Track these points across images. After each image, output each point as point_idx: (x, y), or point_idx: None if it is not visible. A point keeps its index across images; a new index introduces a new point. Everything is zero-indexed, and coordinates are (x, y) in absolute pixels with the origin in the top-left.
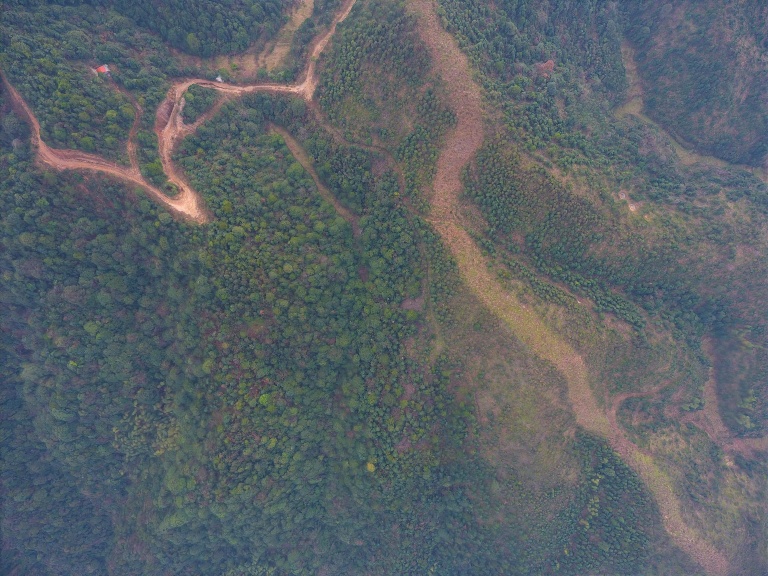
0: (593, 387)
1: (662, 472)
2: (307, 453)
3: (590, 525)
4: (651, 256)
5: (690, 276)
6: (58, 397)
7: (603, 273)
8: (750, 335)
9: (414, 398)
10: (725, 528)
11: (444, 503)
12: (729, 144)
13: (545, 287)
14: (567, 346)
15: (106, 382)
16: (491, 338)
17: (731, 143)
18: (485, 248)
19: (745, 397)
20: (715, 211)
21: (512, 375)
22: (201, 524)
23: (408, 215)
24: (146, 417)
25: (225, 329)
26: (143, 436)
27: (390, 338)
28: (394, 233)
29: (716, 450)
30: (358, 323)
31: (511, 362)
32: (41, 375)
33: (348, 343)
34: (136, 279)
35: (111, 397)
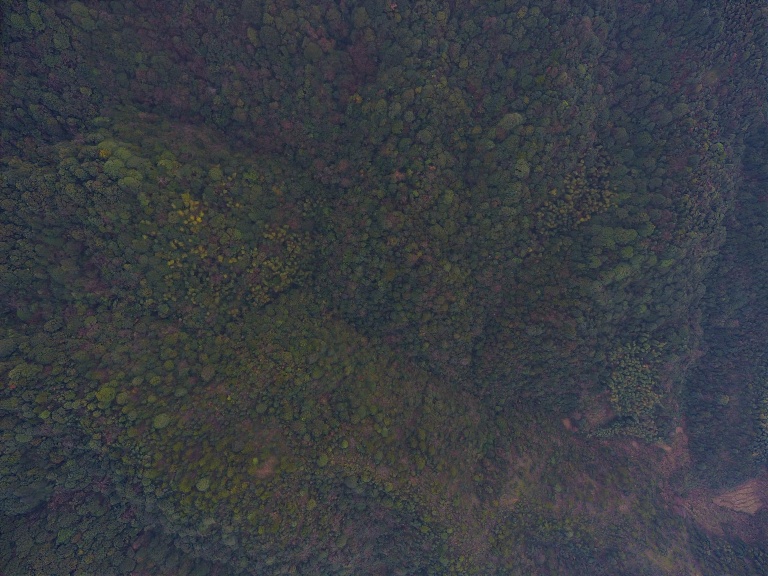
0: None
1: None
2: None
3: None
4: None
5: None
6: (534, 144)
7: None
8: None
9: None
10: None
11: None
12: None
13: None
14: None
15: (569, 134)
16: None
17: None
18: None
19: None
20: None
21: None
22: (626, 285)
23: None
24: (582, 180)
25: (704, 70)
26: None
27: None
28: None
29: None
30: None
31: None
32: (520, 122)
33: None
34: (611, 30)
35: (568, 152)
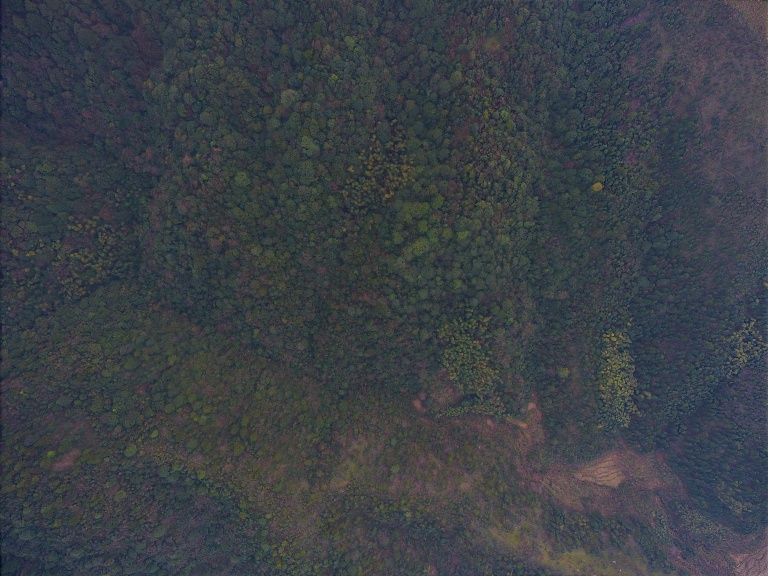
0: None
1: None
2: (527, 189)
3: None
4: None
5: None
6: (313, 120)
7: None
8: None
9: (642, 108)
10: None
11: (650, 242)
12: None
13: None
14: None
15: (353, 109)
16: (722, 34)
17: None
18: None
19: None
20: None
21: (742, 70)
22: (433, 260)
23: None
24: (379, 156)
25: (475, 36)
26: (374, 178)
27: (611, 59)
28: None
29: None
30: (572, 57)
31: (742, 55)
32: (297, 99)
33: (565, 75)
34: (383, 0)
35: (355, 127)
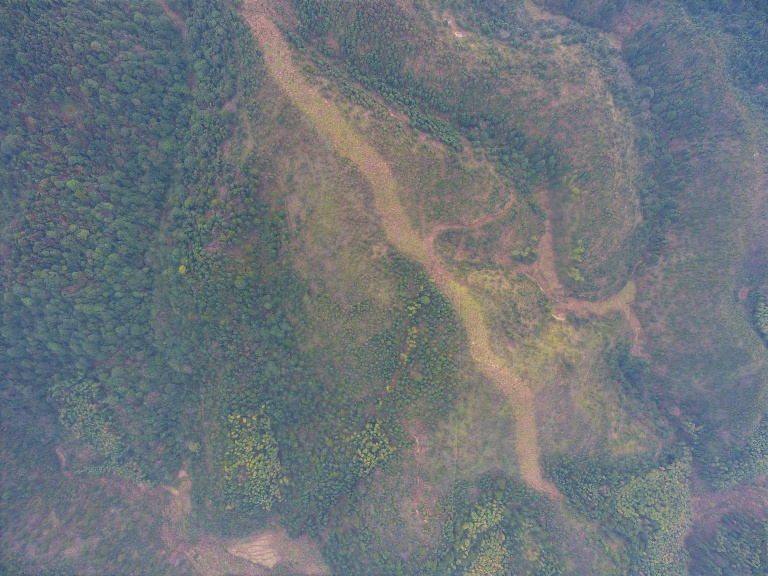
0: (404, 203)
1: (475, 302)
2: (128, 260)
3: (410, 359)
4: (470, 79)
5: (515, 110)
6: None
7: (424, 94)
8: (579, 183)
9: (224, 197)
10: (535, 363)
11: (268, 328)
12: (579, 2)
13: (352, 88)
14: (370, 149)
15: None
16: (295, 134)
17: (580, 1)
18: (293, 42)
19: (575, 248)
20: (544, 49)
21: (314, 173)
22: (16, 320)
23: (224, 9)
24: None
25: (31, 102)
26: None
27: (208, 141)
28: (211, 28)
29: (546, 302)
30: (185, 132)
31: (313, 158)
32: None
33: (172, 149)
34: None
35: None
